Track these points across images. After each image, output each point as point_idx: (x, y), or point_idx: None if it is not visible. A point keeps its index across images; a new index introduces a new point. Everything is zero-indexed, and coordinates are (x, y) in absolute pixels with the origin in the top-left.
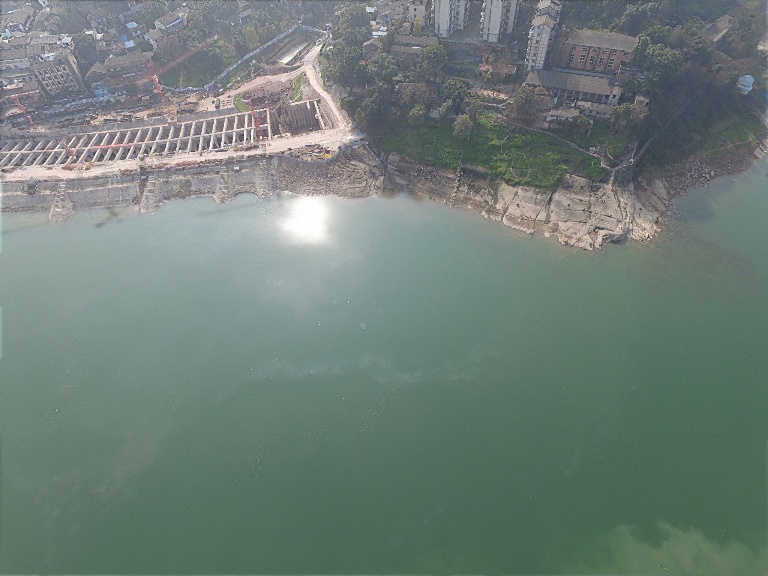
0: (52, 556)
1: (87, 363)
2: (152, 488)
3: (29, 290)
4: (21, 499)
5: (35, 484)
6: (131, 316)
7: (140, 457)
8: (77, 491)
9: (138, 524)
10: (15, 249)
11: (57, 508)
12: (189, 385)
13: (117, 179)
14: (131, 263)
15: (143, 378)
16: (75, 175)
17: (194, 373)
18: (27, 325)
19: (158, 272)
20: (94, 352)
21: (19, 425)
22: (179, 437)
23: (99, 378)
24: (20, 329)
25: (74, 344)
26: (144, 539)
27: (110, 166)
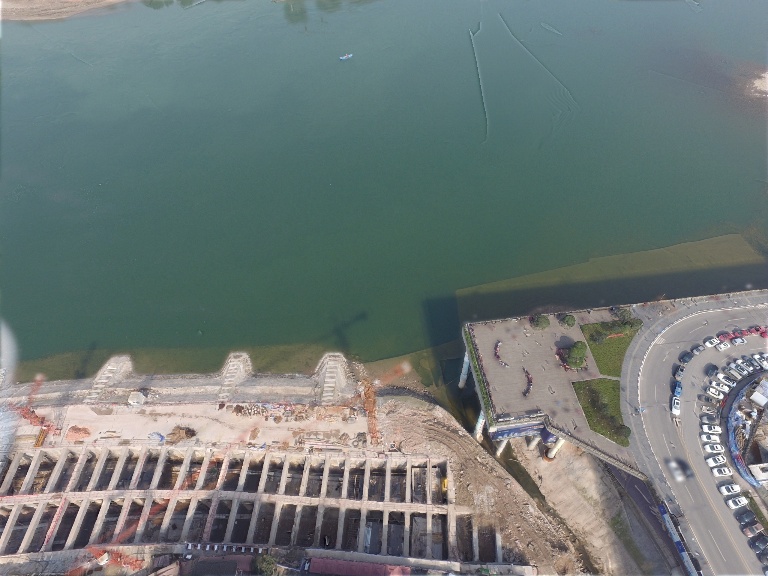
0: (93, 133)
1: (83, 213)
2: (52, 165)
3: (141, 270)
4: (114, 149)
5: (106, 153)
6: (42, 245)
7: (43, 162)
8: (82, 151)
9: (61, 153)
10: (166, 316)
11: (92, 146)
12: (6, 199)
13: (6, 408)
14: (33, 296)
15: (41, 205)
16: (67, 413)
17: (2, 207)
18: (135, 238)
19: (5, 284)
20: (77, 220)
21: (126, 180)
22: (24, 177)
23: (75, 206)
24: (140, 235)
25: (92, 224)
26: (51, 142)
27: (7, 434)
